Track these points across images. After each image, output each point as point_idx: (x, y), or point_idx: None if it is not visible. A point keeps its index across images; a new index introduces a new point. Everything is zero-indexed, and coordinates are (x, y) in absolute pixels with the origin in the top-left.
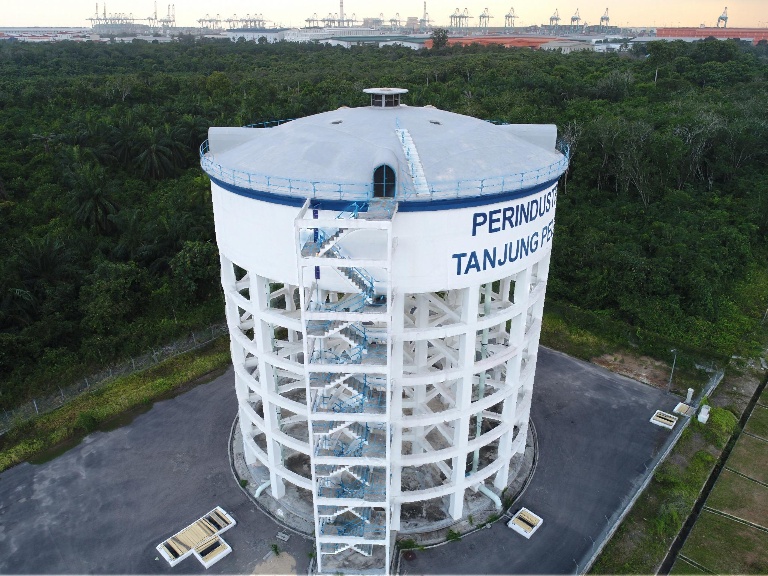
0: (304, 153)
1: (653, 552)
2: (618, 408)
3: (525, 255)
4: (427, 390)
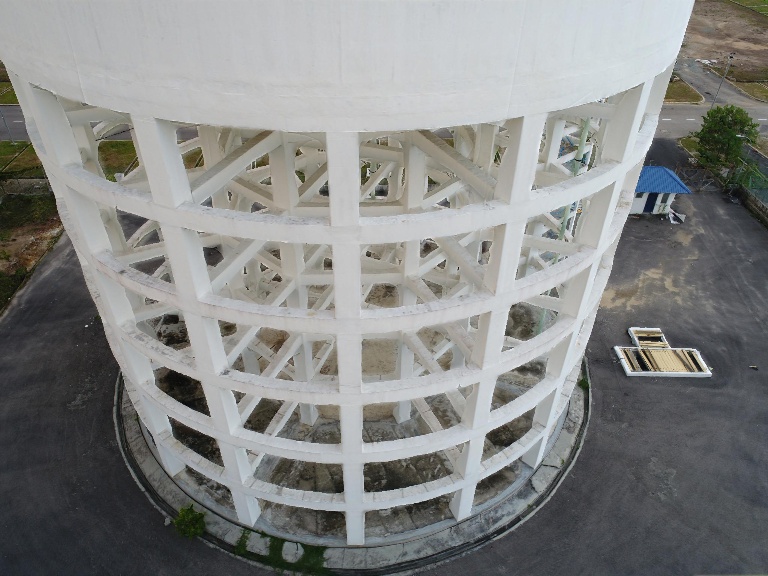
0: None
1: None
2: None
3: None
4: None
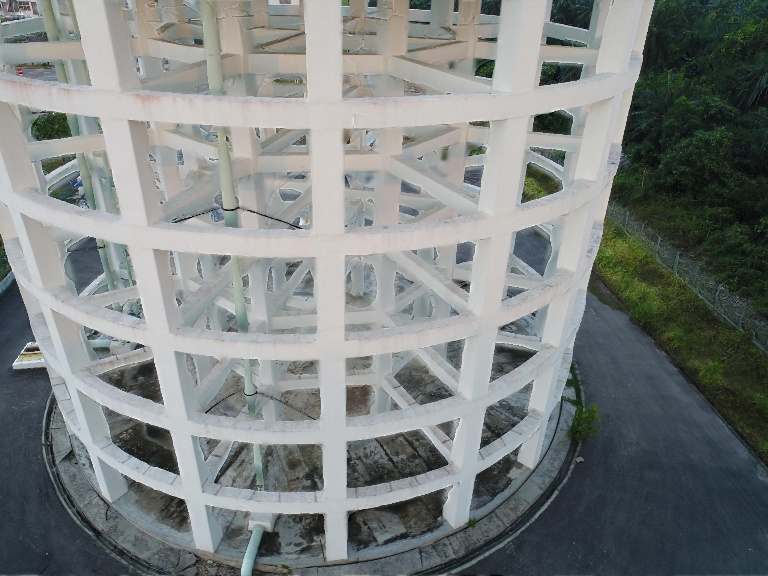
0: None
1: None
2: None
3: None
4: None
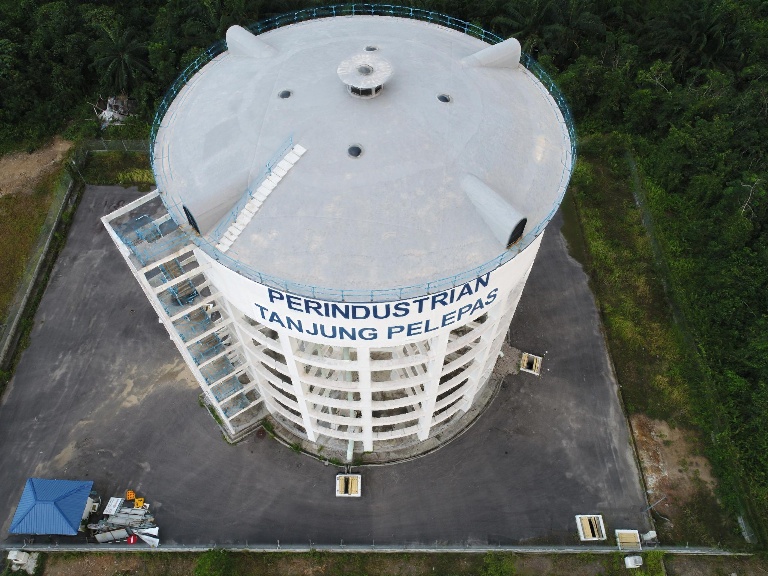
0: (214, 126)
1: None
2: (569, 479)
3: (350, 339)
4: None
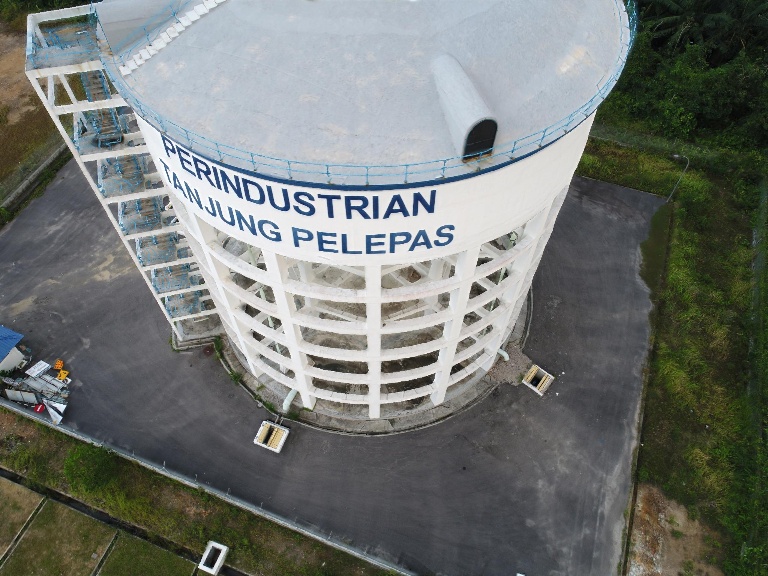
0: None
1: (276, 572)
2: (528, 527)
3: (251, 232)
4: (441, 299)
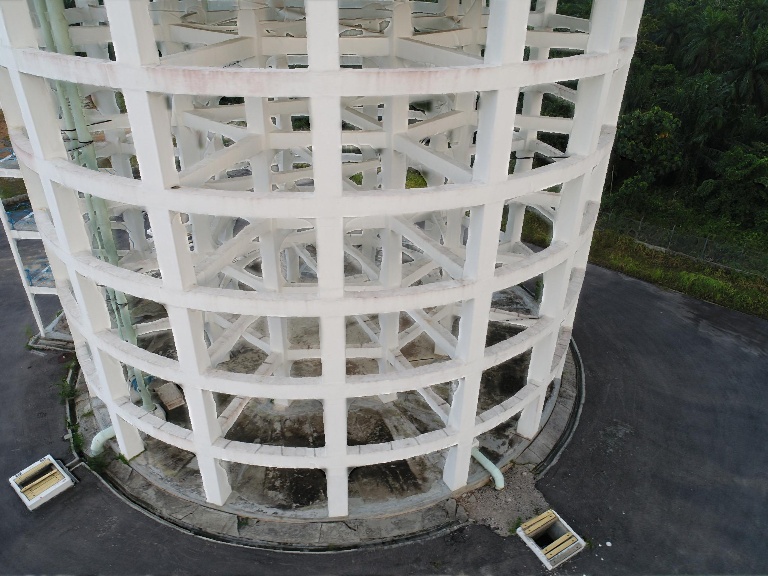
0: None
1: None
2: None
3: None
4: None
